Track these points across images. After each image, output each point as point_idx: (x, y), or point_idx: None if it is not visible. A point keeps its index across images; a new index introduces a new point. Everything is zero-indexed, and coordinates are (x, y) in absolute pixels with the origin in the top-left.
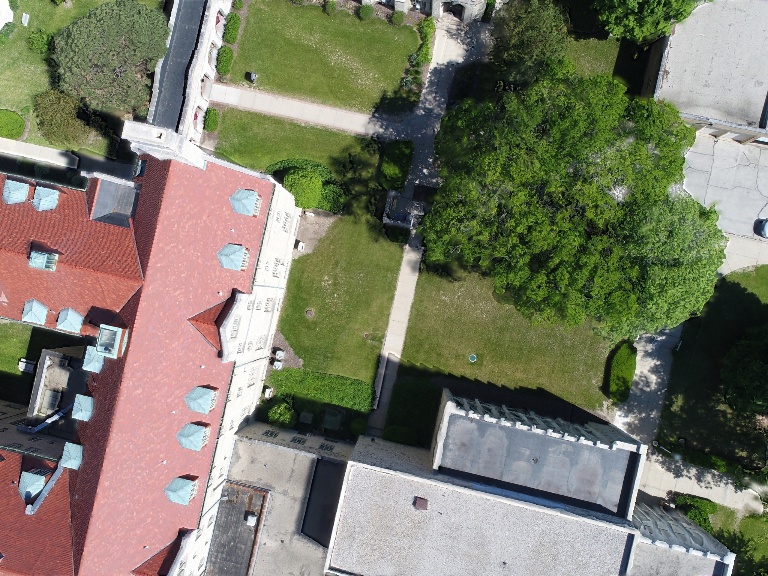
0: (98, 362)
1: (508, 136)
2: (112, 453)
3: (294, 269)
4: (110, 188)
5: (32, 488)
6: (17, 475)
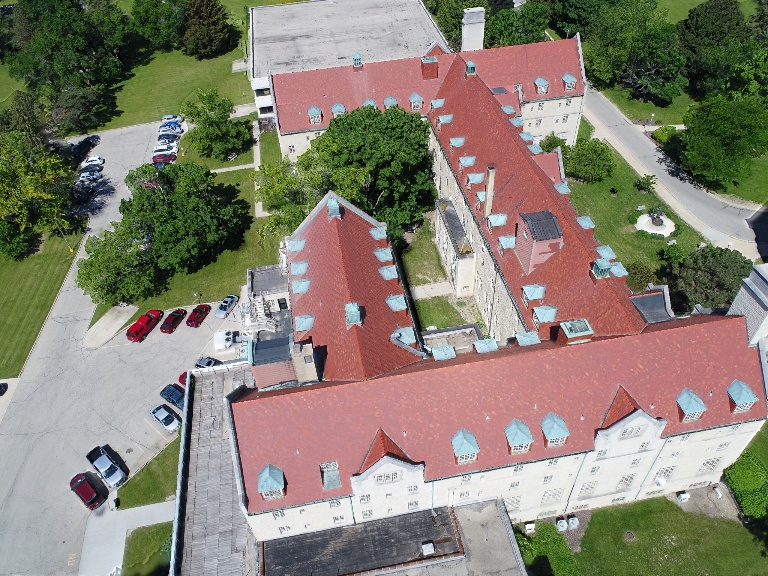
0: (531, 341)
1: None
2: (490, 365)
3: (657, 501)
4: (658, 302)
5: (405, 336)
6: (403, 326)
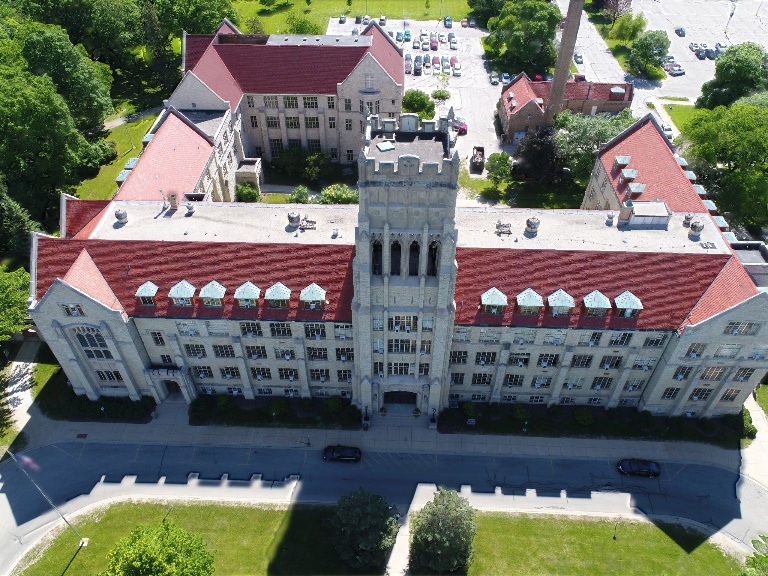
0: None
1: (764, 139)
2: None
3: None
4: None
5: None
6: None
